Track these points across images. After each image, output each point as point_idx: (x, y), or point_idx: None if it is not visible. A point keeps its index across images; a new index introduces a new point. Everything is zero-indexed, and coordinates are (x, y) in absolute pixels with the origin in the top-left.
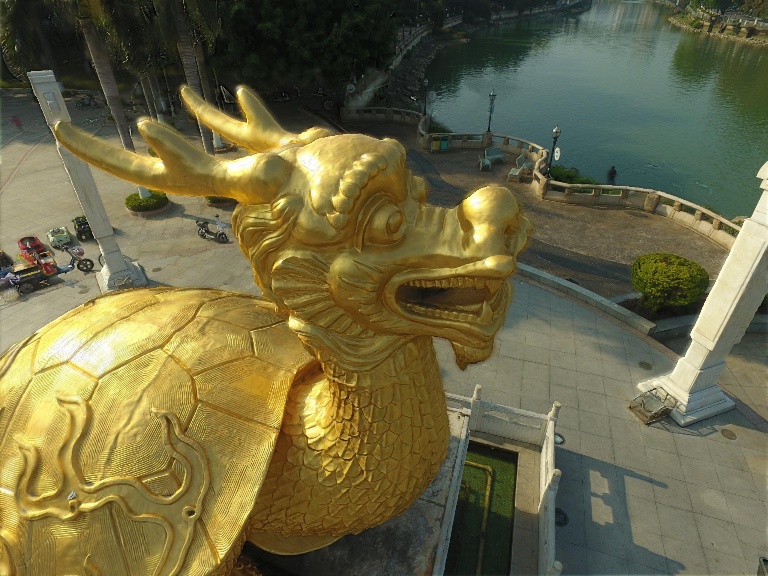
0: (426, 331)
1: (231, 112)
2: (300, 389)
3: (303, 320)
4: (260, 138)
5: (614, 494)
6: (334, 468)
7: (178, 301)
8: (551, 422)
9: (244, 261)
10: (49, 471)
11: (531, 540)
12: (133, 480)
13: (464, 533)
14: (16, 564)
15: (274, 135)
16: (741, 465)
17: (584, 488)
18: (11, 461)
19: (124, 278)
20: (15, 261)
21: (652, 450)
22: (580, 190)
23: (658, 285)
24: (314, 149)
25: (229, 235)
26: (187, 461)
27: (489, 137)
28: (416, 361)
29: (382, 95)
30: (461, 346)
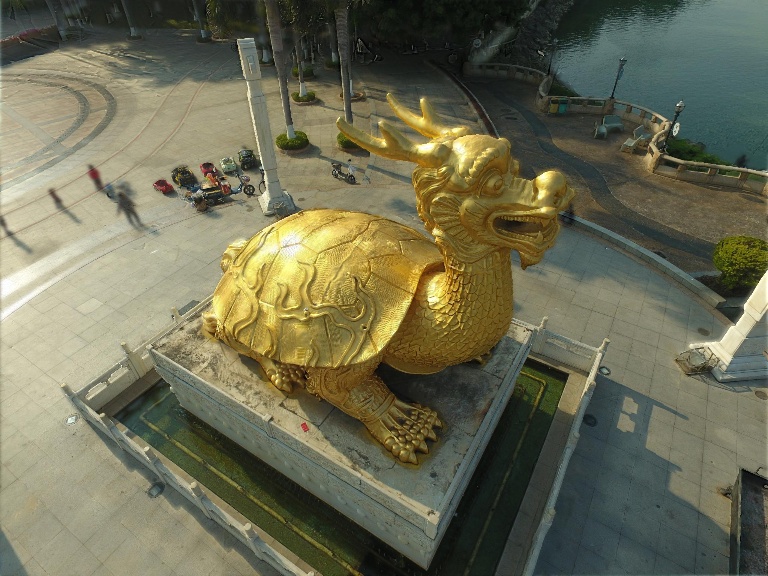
0: (506, 244)
1: (362, 61)
2: (426, 277)
3: (442, 231)
4: (429, 128)
5: (640, 415)
6: (442, 320)
7: (356, 218)
8: (600, 354)
9: (368, 200)
10: (293, 296)
11: (564, 429)
12: (337, 306)
13: (515, 418)
14: (275, 339)
15: (438, 128)
16: (762, 418)
17: (617, 406)
18: (272, 290)
19: (280, 203)
20: (199, 181)
21: (685, 393)
22: (695, 168)
23: (735, 265)
24: (463, 143)
25: (356, 177)
26: (364, 302)
27: (611, 104)
28: (498, 263)
29: (508, 51)
30: (524, 254)
